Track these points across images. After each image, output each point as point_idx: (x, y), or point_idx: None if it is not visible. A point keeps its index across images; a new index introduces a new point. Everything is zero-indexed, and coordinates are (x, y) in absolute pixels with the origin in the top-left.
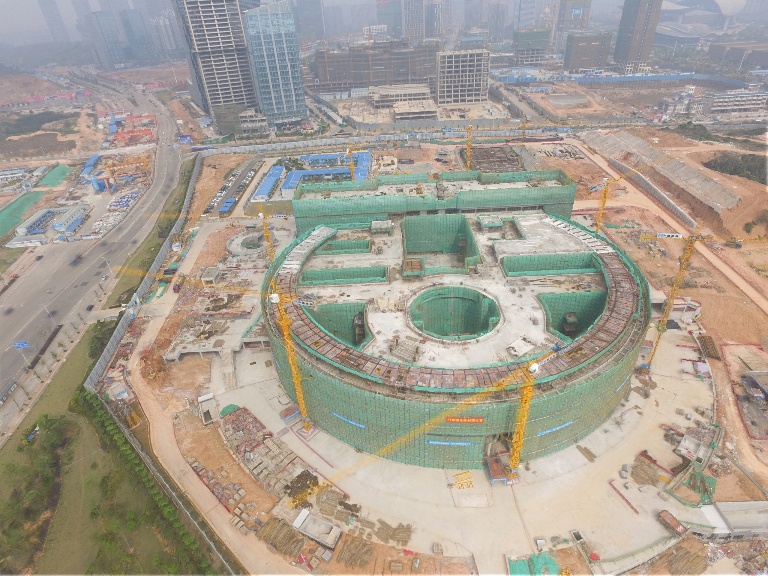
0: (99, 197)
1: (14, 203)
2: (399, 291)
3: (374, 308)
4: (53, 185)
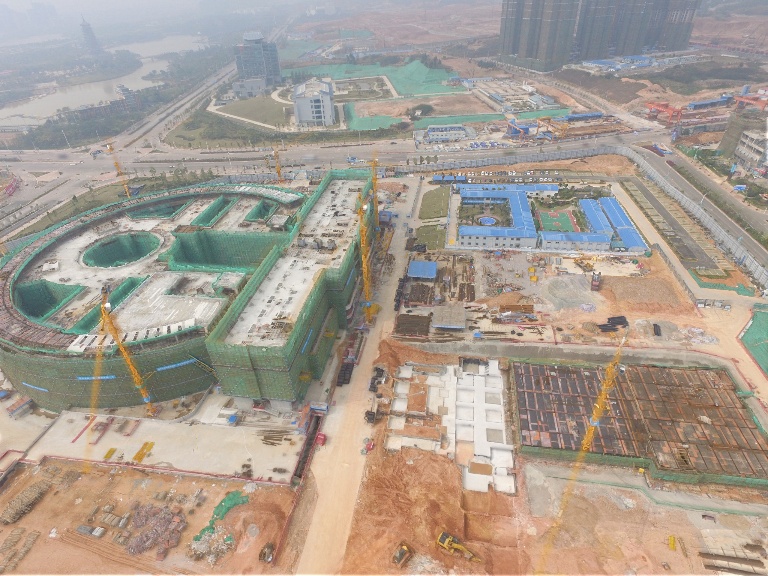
0: (499, 136)
1: (476, 115)
2: (172, 230)
3: (165, 221)
4: (521, 117)
